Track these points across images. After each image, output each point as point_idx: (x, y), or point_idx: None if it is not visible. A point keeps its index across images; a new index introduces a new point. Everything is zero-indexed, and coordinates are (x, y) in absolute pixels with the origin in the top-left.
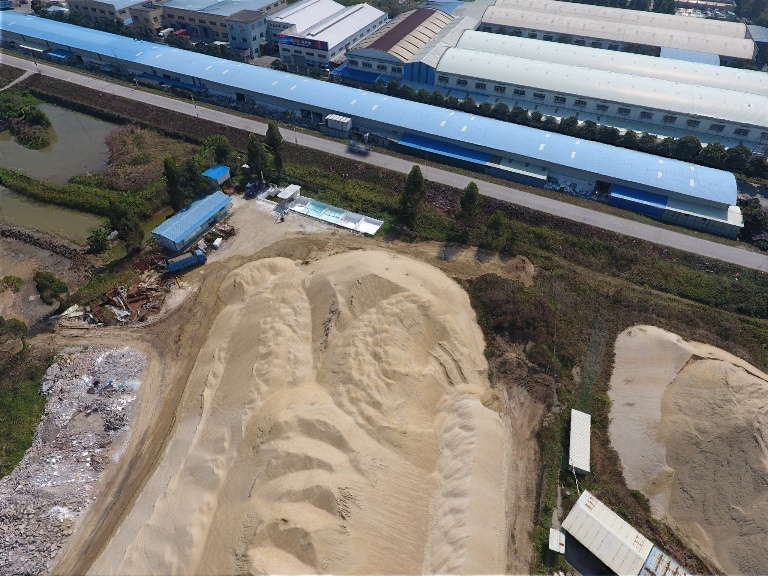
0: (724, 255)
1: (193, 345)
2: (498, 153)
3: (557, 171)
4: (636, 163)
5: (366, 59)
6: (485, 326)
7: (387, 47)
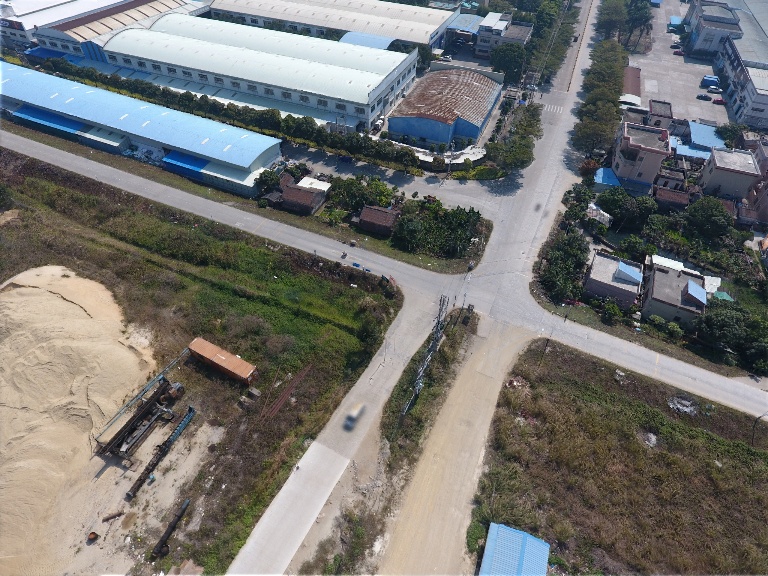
0: (201, 209)
1: None
2: (90, 123)
3: (135, 139)
4: (195, 131)
5: (50, 38)
6: None
7: (69, 27)
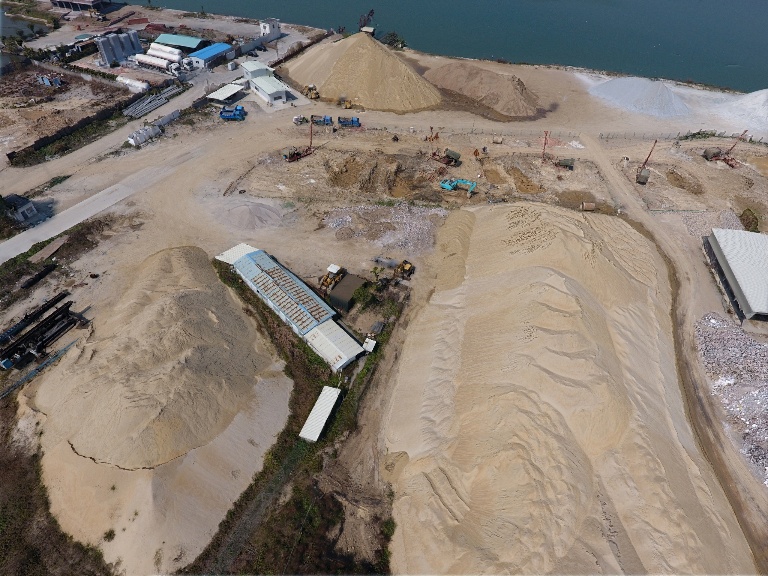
0: None
1: (767, 563)
2: None
3: None
4: None
5: None
6: None
7: None
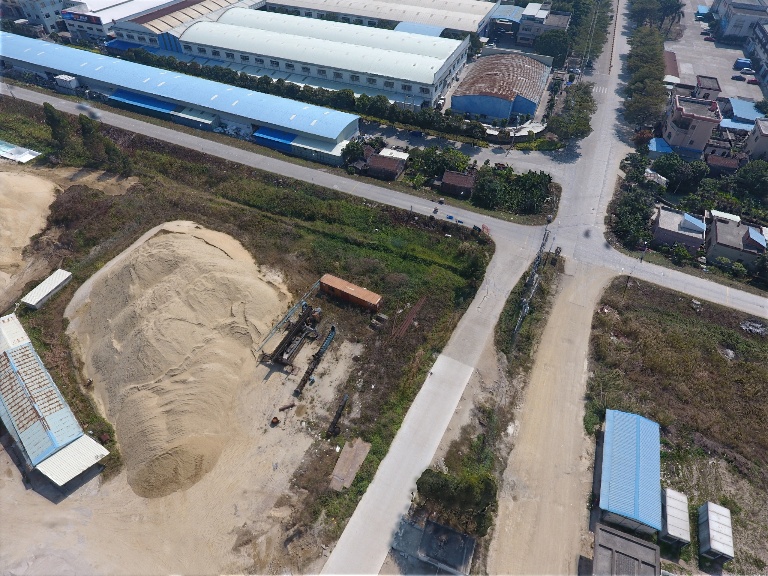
0: (299, 175)
1: None
2: (182, 104)
3: (225, 117)
4: (281, 109)
5: (128, 31)
6: (49, 220)
7: (146, 21)
